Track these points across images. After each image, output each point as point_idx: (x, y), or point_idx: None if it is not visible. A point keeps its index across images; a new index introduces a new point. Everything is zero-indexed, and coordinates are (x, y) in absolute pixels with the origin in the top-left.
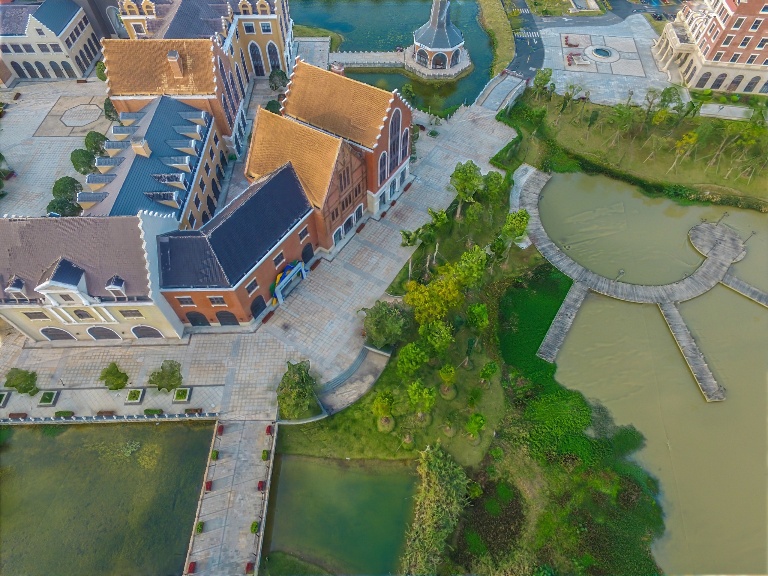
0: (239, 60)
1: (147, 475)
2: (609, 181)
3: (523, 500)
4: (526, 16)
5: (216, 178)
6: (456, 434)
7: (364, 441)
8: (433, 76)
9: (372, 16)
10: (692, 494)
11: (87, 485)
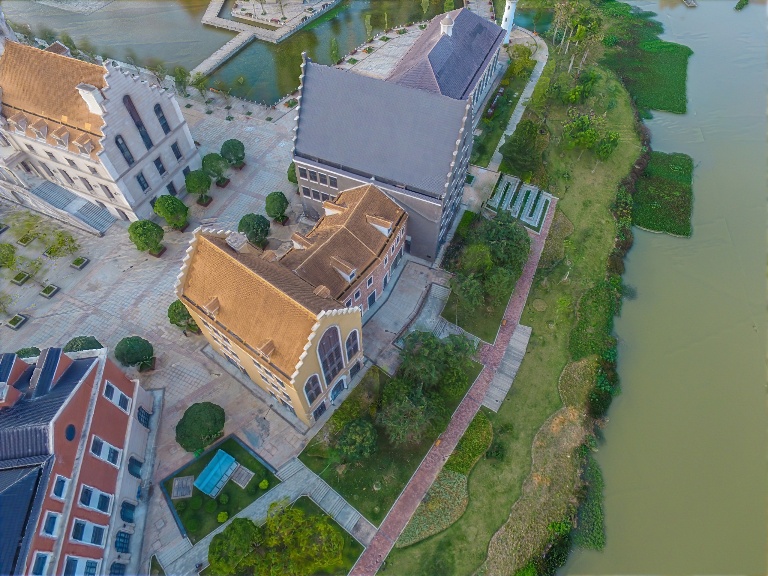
0: None
1: (437, 5)
2: None
3: (601, 24)
4: None
5: None
6: None
7: (529, 2)
8: None
9: None
10: (677, 26)
11: (412, 6)
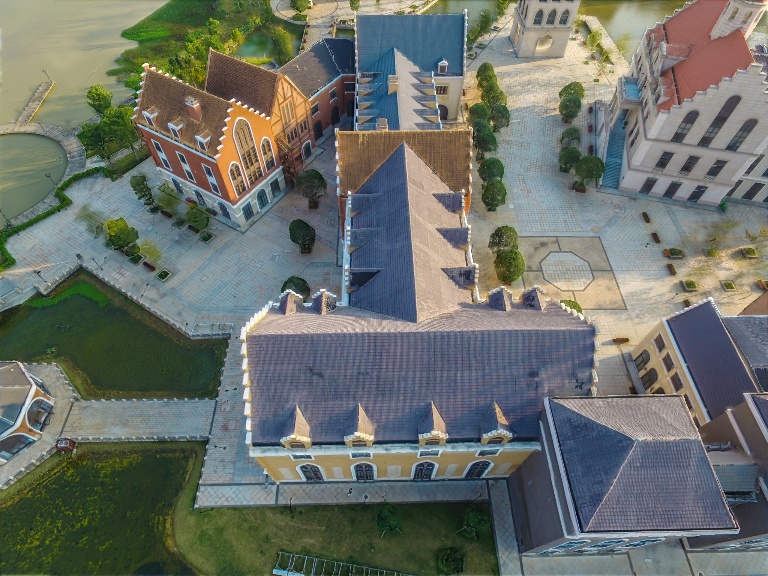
0: None
1: None
2: None
3: None
4: None
5: None
6: None
7: (255, 59)
8: None
9: None
10: None
11: None
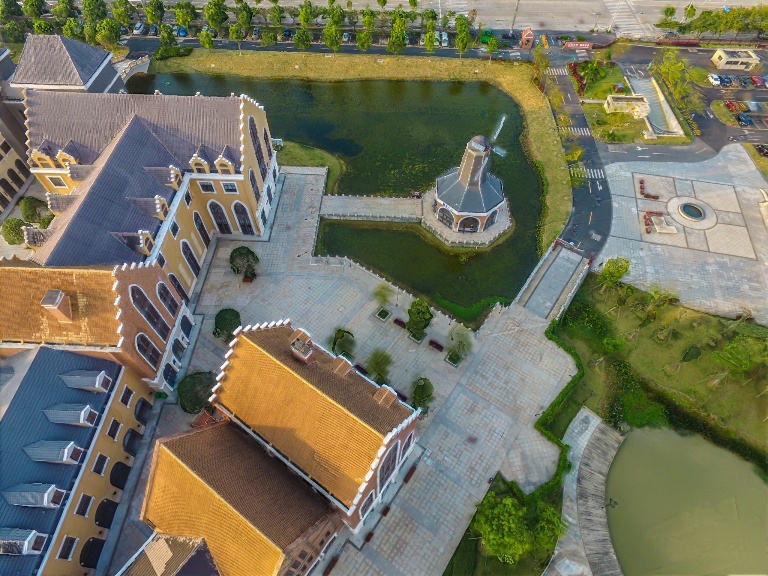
0: (191, 230)
1: None
2: (710, 448)
3: None
4: (586, 141)
5: (123, 455)
6: None
7: None
8: (459, 244)
9: (385, 130)
10: None
11: None
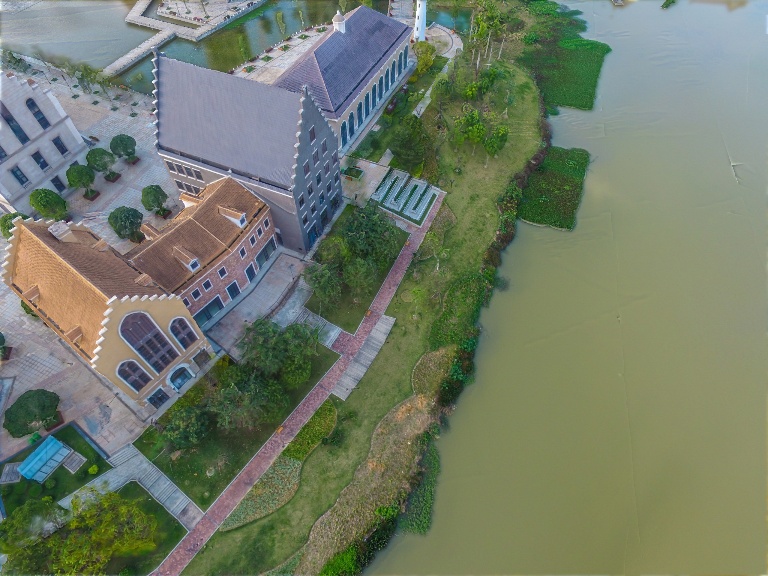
0: None
1: None
2: None
3: (525, 22)
4: None
5: None
6: (496, 2)
7: None
8: None
9: None
10: (601, 24)
11: (339, 5)
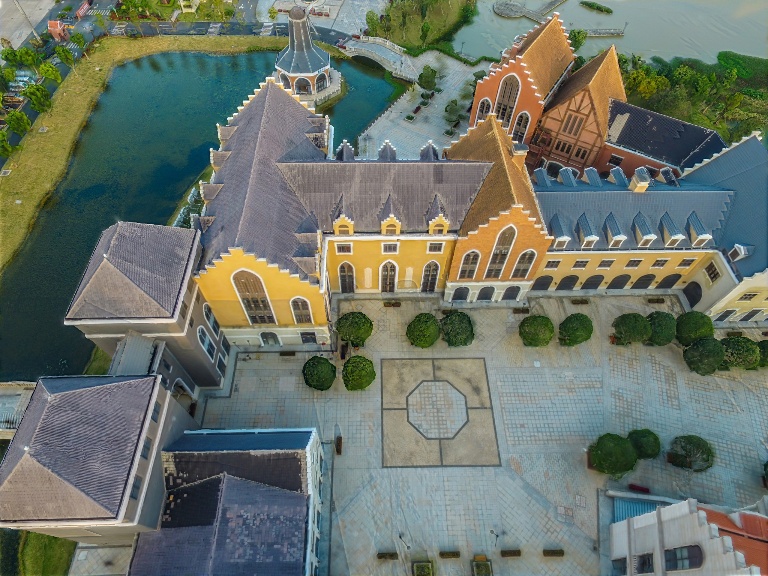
0: None
1: None
2: (458, 34)
3: None
4: None
5: None
6: None
7: None
8: (340, 86)
9: (180, 128)
10: (676, 49)
11: None
